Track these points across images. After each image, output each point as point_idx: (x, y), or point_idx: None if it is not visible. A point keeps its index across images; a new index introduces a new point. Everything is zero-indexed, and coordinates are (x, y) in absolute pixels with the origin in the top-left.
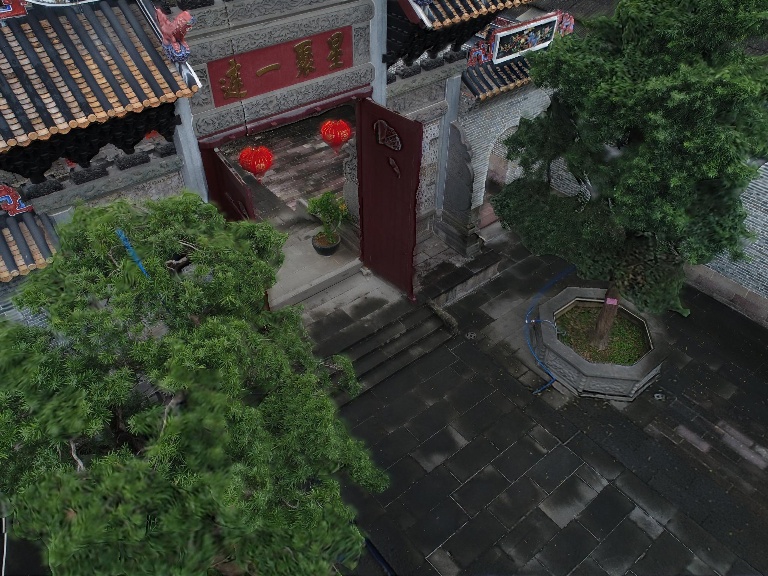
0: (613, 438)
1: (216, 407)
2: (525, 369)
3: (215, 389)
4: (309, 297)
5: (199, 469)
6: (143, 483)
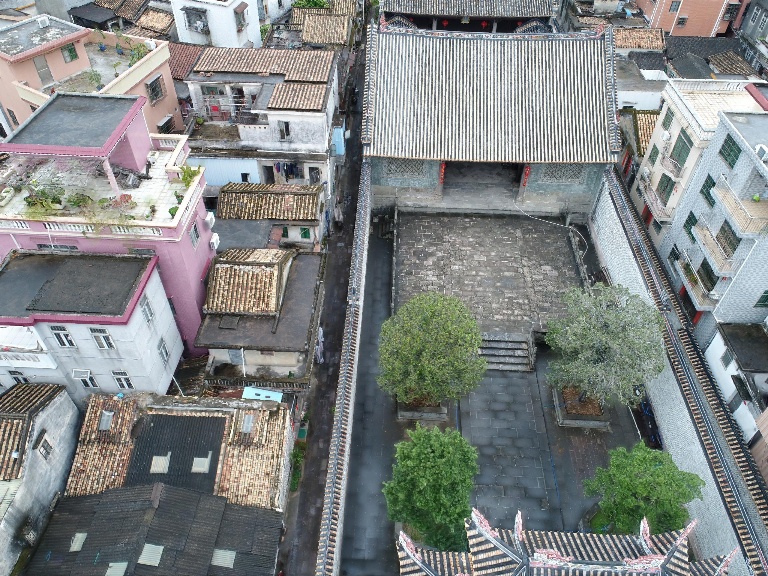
0: None
1: None
2: None
3: None
4: None
5: (646, 451)
6: None
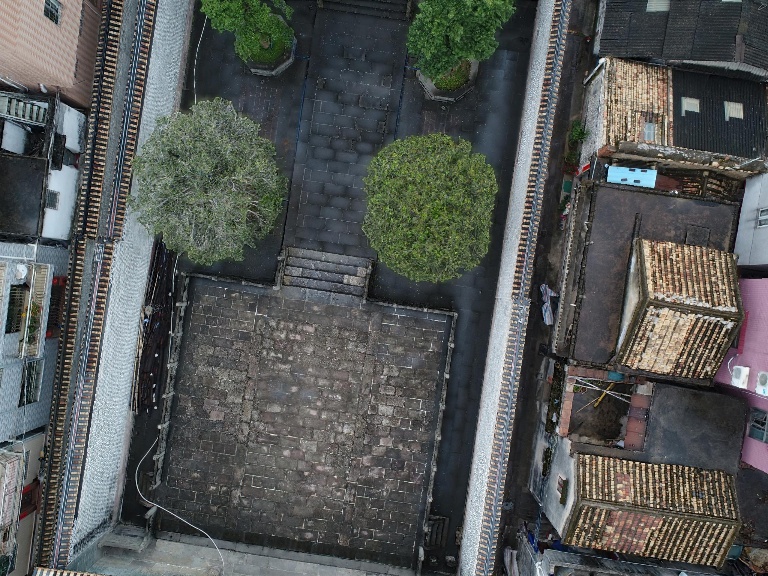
0: (409, 103)
1: (234, 6)
2: (416, 56)
3: (236, 3)
4: None
5: (227, 14)
6: (217, 9)
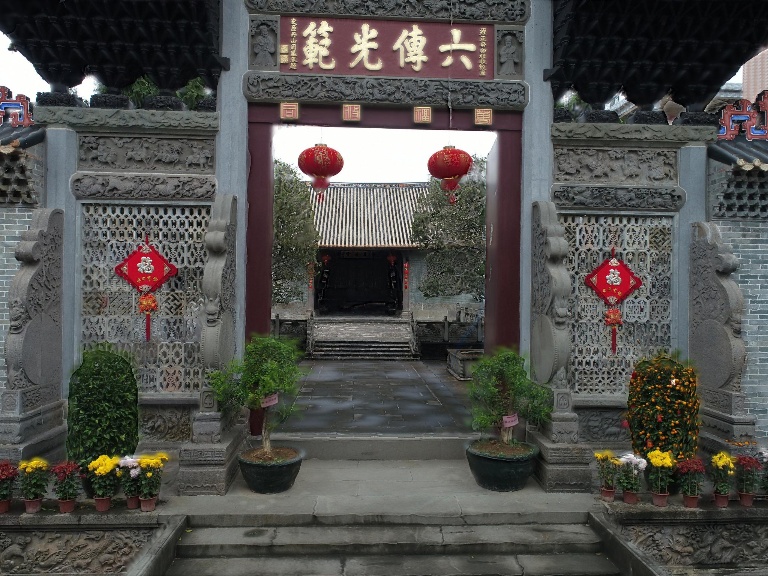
0: None
1: None
2: None
3: None
4: None
5: None
6: None
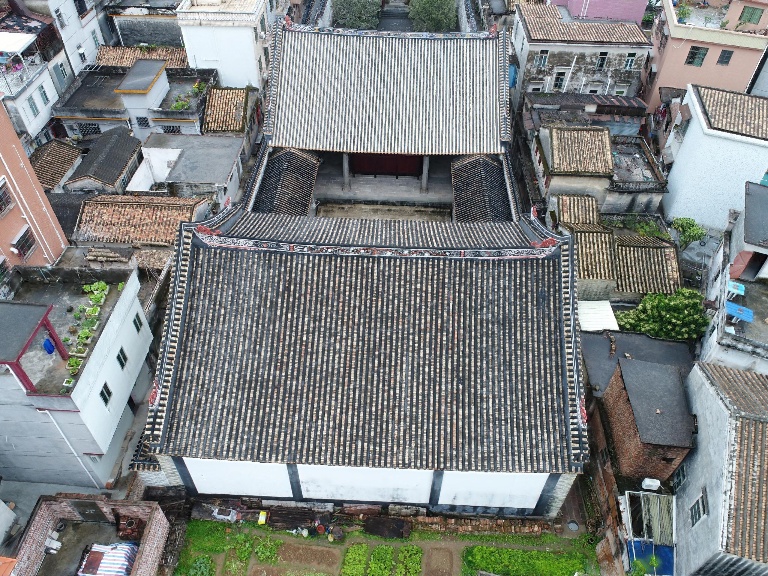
0: None
1: None
2: None
3: None
4: (396, 7)
5: None
6: None
